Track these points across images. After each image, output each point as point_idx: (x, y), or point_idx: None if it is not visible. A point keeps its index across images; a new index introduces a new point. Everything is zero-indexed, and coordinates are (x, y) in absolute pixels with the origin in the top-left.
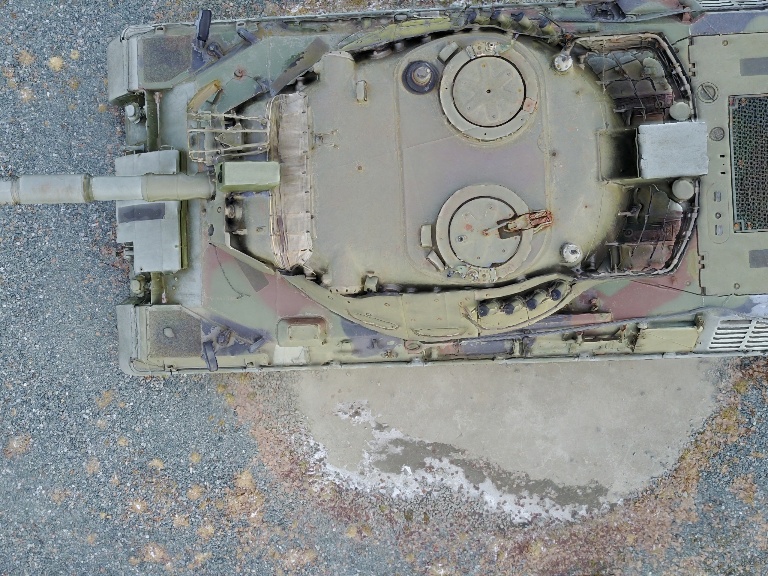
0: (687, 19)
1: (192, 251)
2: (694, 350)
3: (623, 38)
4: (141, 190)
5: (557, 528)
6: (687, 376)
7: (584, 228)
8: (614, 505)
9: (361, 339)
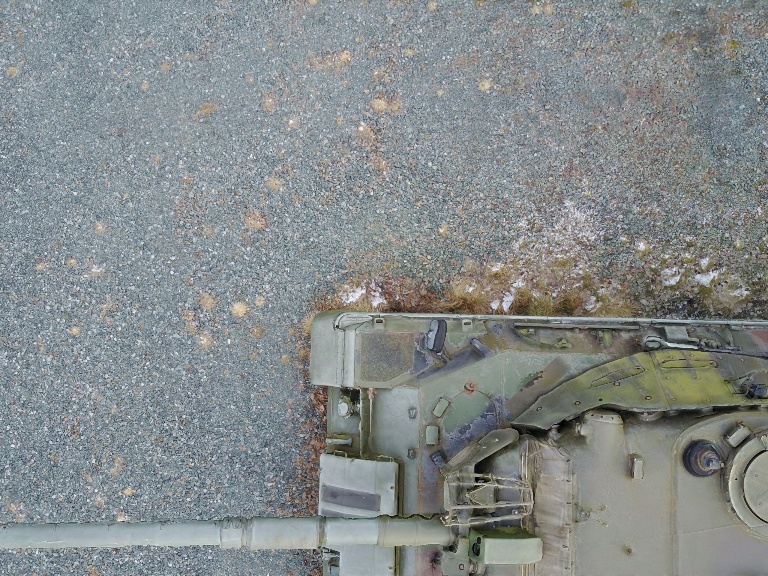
0: None
1: (405, 571)
2: None
3: None
4: (377, 539)
5: None
6: None
7: None
8: None
9: None
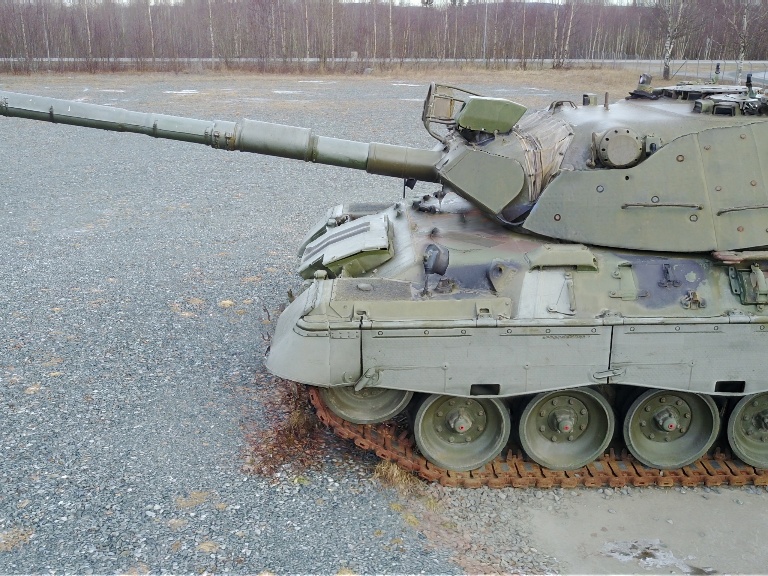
0: None
1: (400, 248)
2: None
3: None
4: (369, 145)
5: None
6: None
7: None
8: None
9: (647, 267)
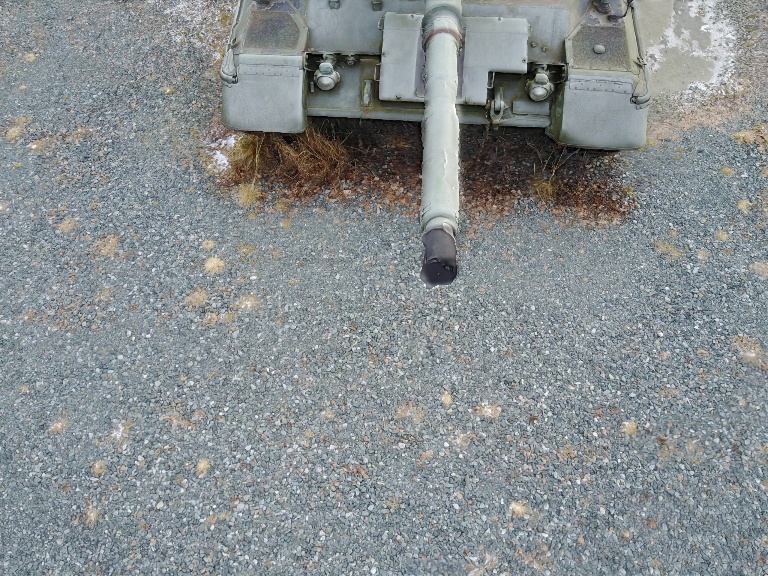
0: None
1: None
2: None
3: None
4: None
5: None
6: None
7: None
8: None
9: None
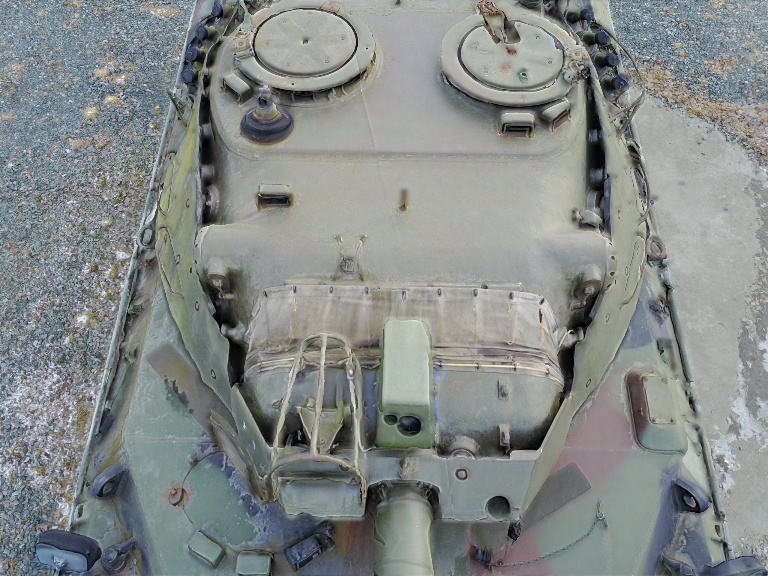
0: None
1: None
2: None
3: None
4: None
5: None
6: None
7: None
8: None
9: (652, 327)
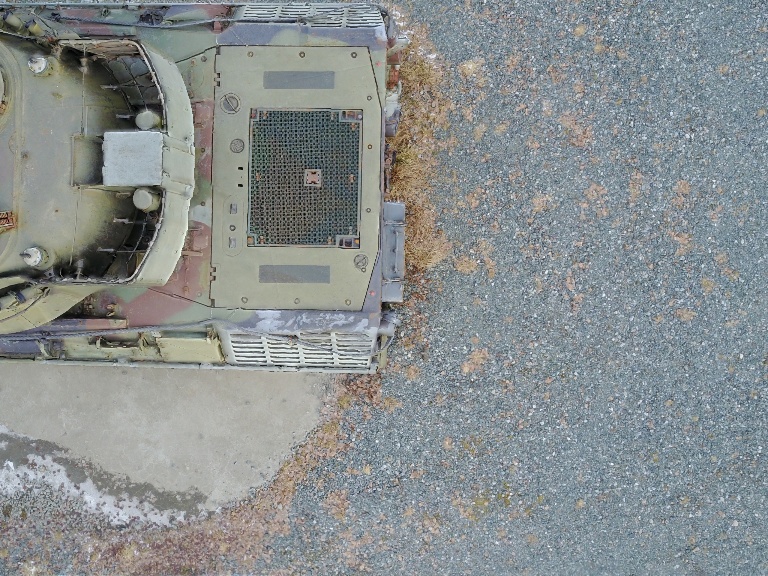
0: (218, 28)
1: None
2: (228, 362)
3: (106, 43)
4: None
5: (154, 532)
6: (293, 388)
7: (57, 232)
8: (212, 513)
9: None
